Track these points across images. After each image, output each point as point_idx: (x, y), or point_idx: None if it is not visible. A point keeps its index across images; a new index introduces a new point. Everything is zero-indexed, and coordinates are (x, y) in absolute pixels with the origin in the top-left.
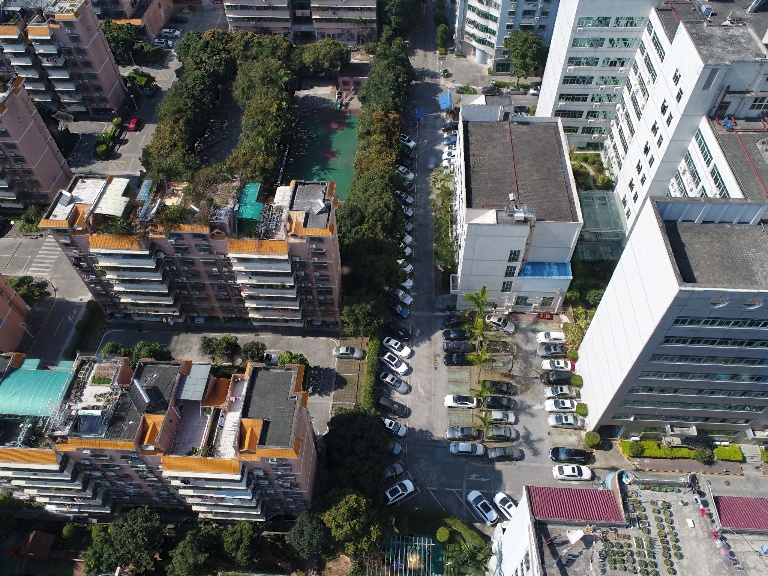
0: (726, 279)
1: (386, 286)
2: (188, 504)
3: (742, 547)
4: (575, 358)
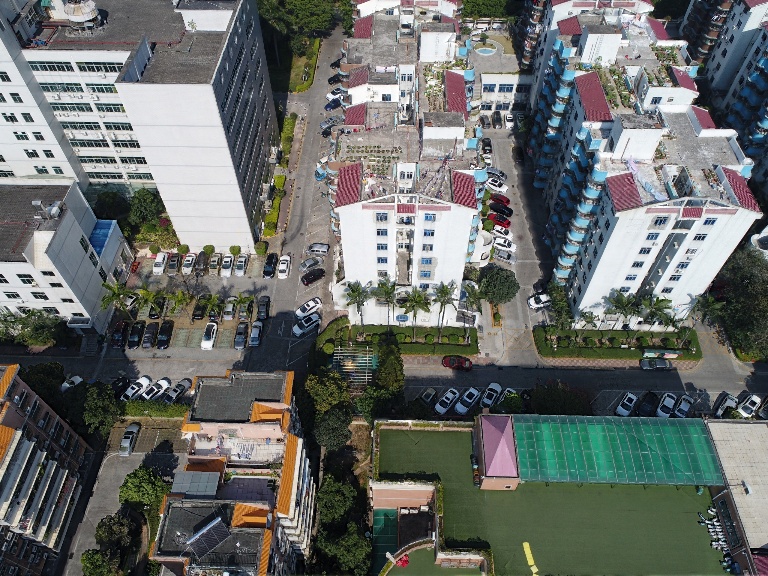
0: (198, 76)
1: (61, 384)
2: (294, 569)
3: (373, 124)
4: (187, 247)
